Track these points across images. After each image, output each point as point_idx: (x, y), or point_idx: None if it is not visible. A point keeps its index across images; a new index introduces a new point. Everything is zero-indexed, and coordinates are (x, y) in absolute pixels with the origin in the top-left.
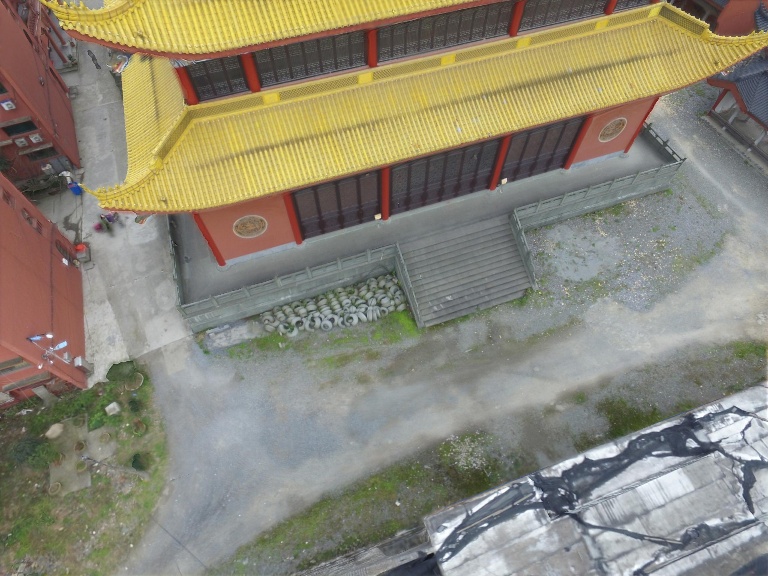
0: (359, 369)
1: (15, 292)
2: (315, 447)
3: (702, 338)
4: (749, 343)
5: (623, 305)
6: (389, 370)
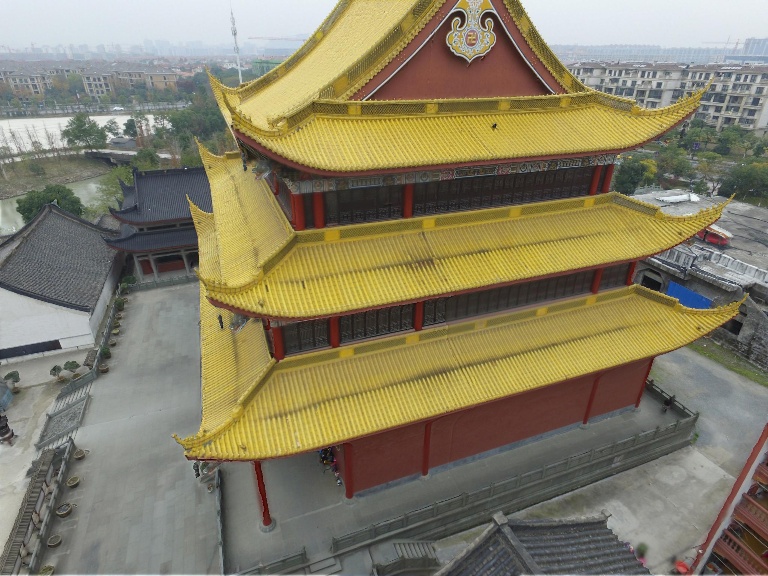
0: None
1: None
2: (707, 374)
3: None
4: None
5: None
6: None
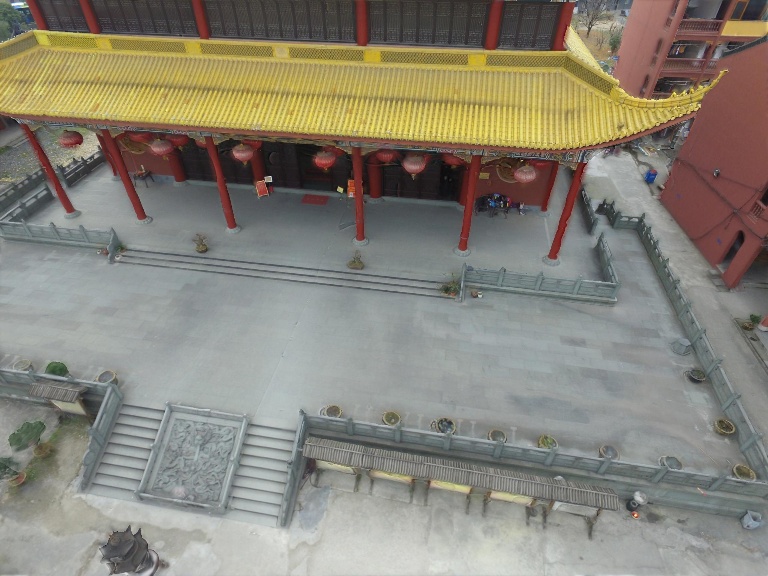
0: None
1: (630, 53)
2: None
3: None
4: None
5: None
6: None
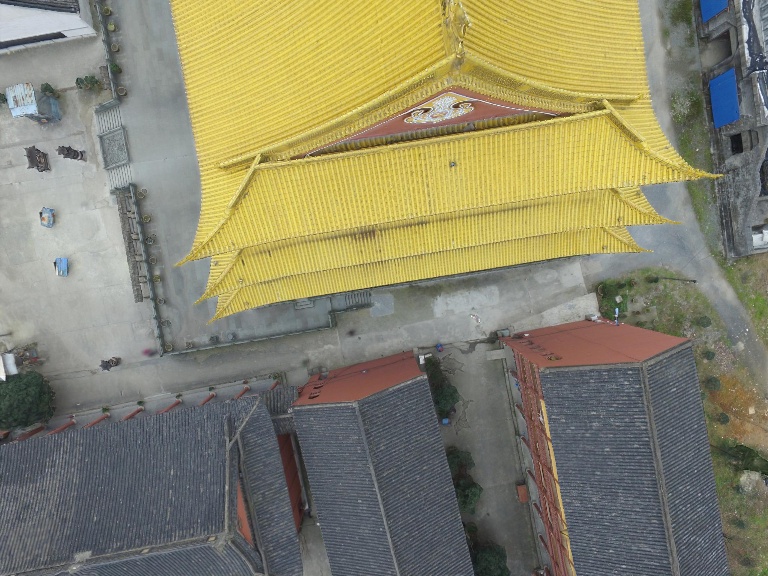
0: None
1: None
2: (661, 189)
3: None
4: None
5: None
6: None
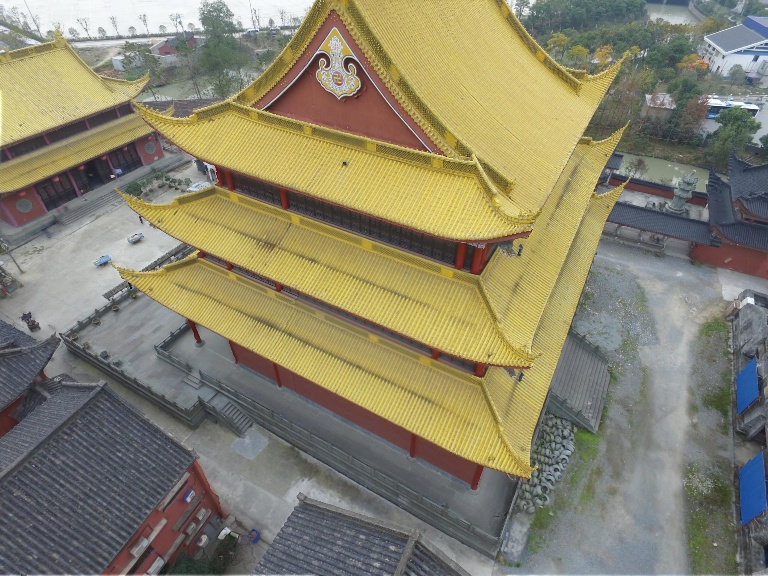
0: (603, 487)
1: None
2: (647, 558)
3: (689, 338)
4: (703, 327)
5: (648, 345)
6: (615, 473)
